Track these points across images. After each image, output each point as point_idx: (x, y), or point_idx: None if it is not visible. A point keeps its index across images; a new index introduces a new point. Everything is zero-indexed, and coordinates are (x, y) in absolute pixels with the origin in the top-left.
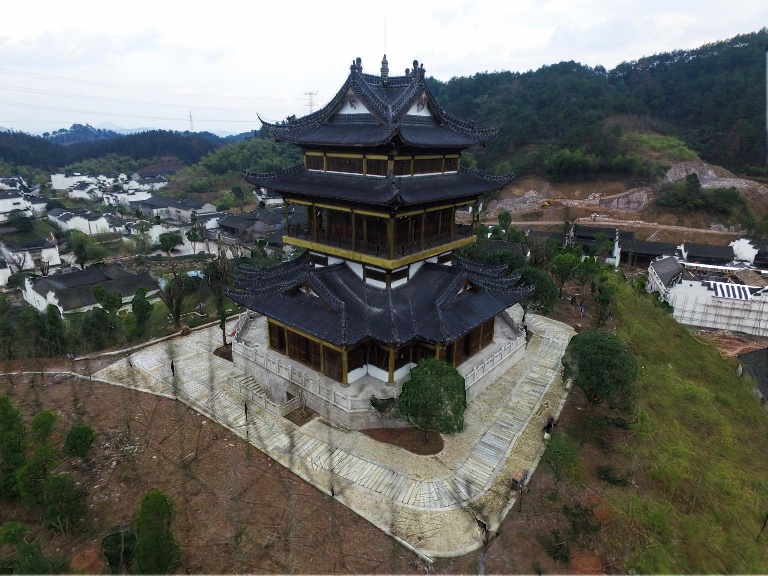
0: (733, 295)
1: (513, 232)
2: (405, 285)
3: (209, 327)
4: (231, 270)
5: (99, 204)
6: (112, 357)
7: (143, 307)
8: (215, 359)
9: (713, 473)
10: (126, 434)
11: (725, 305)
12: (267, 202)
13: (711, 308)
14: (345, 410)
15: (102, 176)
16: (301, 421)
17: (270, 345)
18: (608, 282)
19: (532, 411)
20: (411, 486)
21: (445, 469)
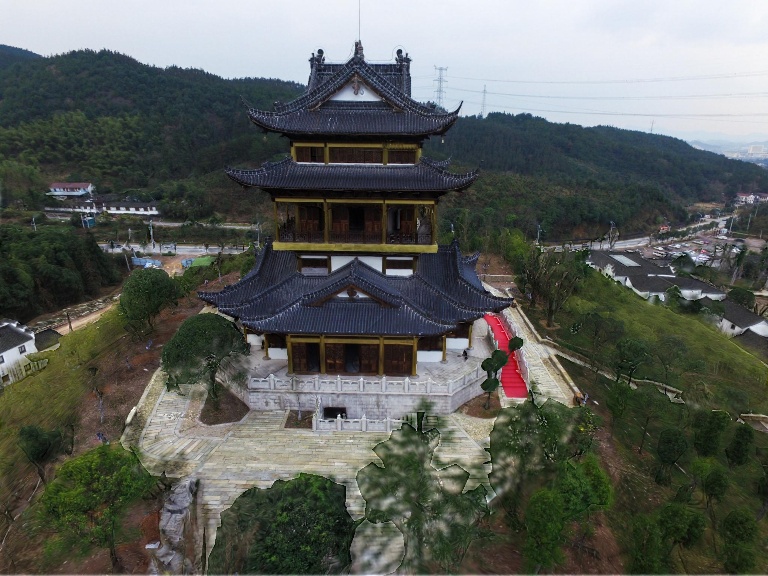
0: None
1: None
2: None
3: (520, 316)
4: None
5: None
6: None
7: None
8: None
9: None
10: None
11: None
12: None
13: None
14: None
15: None
16: None
17: None
18: None
19: None
20: None
21: None
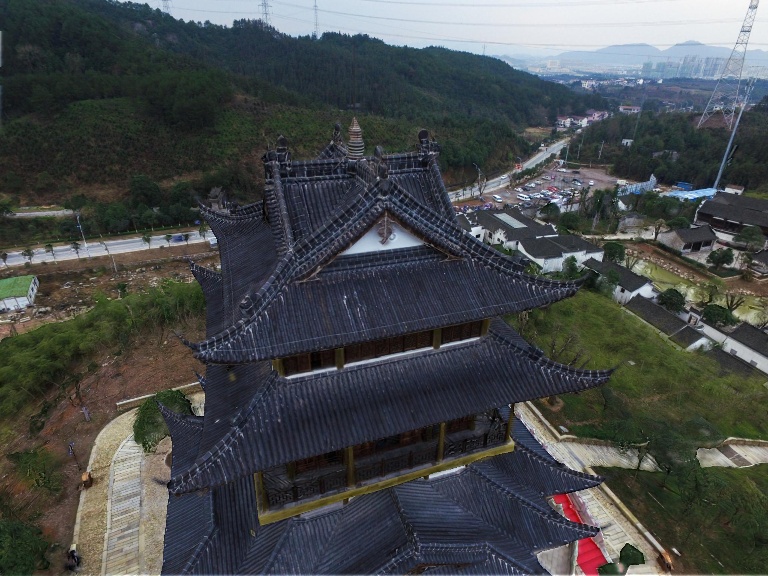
0: None
1: None
2: None
3: None
4: None
5: None
6: None
7: None
8: None
9: None
10: None
11: None
12: None
13: None
14: None
15: None
16: None
17: None
18: None
19: None
20: None
21: None
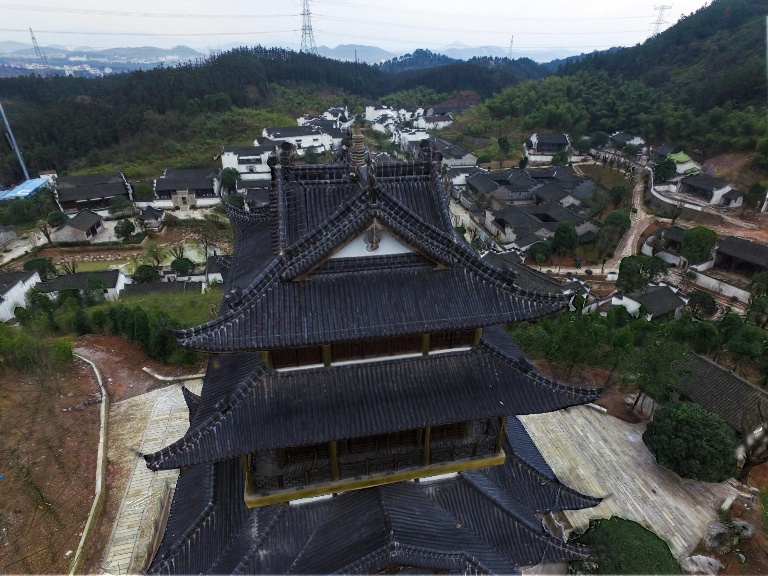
0: None
1: None
2: (326, 501)
3: None
4: None
5: (387, 140)
6: (158, 381)
7: None
8: None
9: None
10: (7, 531)
11: None
12: (533, 158)
13: None
14: None
15: (403, 110)
16: None
17: None
18: None
19: None
20: None
21: None
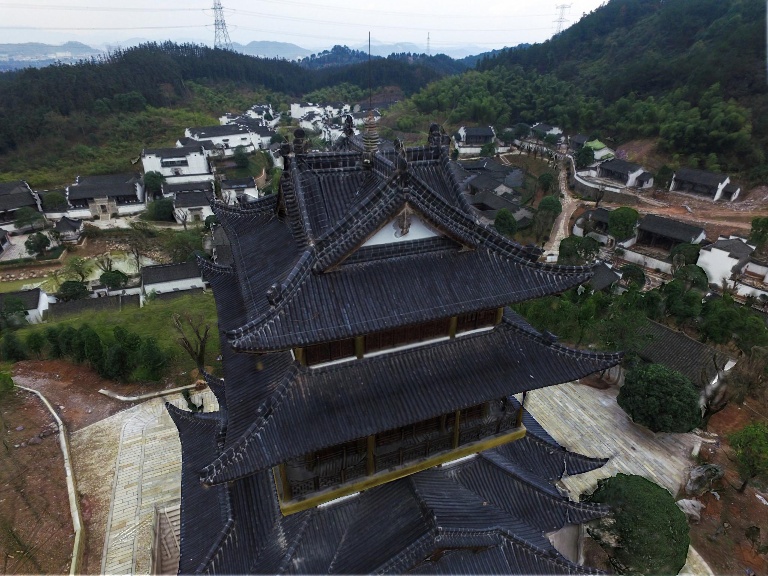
0: None
1: (726, 302)
2: (353, 499)
3: None
4: None
5: (316, 137)
6: (121, 402)
7: (150, 360)
8: None
9: None
10: None
11: None
12: (463, 151)
13: None
14: None
15: (329, 106)
16: None
17: None
18: None
19: None
20: None
21: None
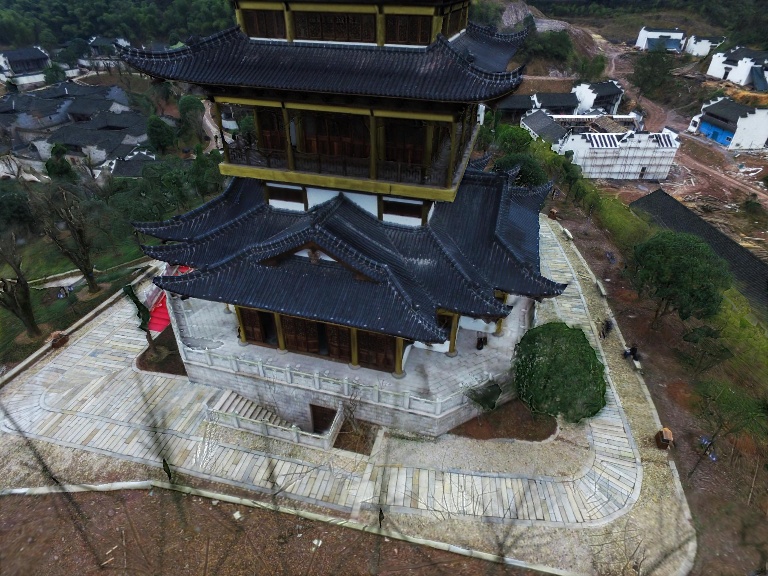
0: (605, 144)
1: None
2: (434, 214)
3: (92, 319)
4: (46, 205)
5: None
6: None
7: None
8: (150, 378)
9: (724, 340)
10: None
11: (599, 155)
12: (17, 82)
13: (588, 160)
14: (432, 416)
15: None
16: (365, 446)
17: (245, 338)
18: (546, 153)
19: (594, 334)
20: (568, 493)
21: (581, 450)
